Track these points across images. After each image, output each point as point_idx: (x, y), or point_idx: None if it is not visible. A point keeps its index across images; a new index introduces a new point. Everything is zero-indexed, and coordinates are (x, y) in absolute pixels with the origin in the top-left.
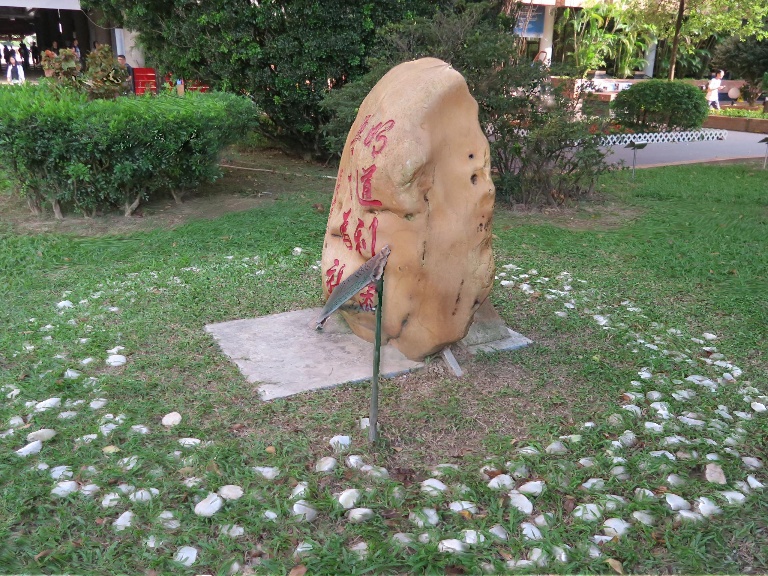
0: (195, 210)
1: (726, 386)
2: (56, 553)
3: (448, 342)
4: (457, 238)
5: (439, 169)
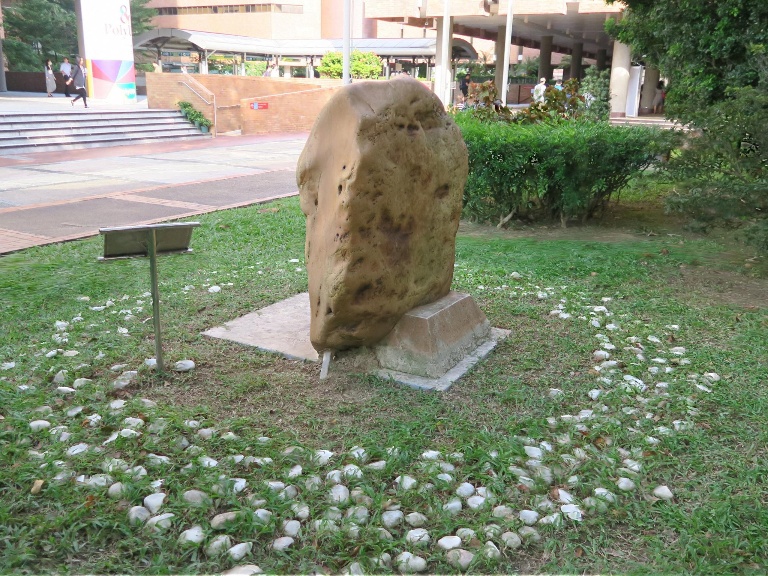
0: (559, 234)
1: (494, 516)
2: None
3: (315, 342)
4: (321, 243)
5: (324, 176)
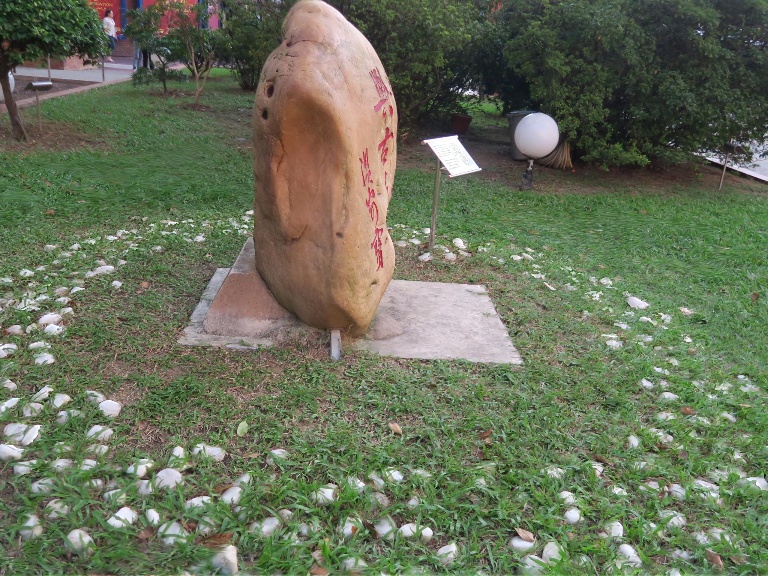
0: None
1: None
2: (595, 262)
3: None
4: None
5: None
